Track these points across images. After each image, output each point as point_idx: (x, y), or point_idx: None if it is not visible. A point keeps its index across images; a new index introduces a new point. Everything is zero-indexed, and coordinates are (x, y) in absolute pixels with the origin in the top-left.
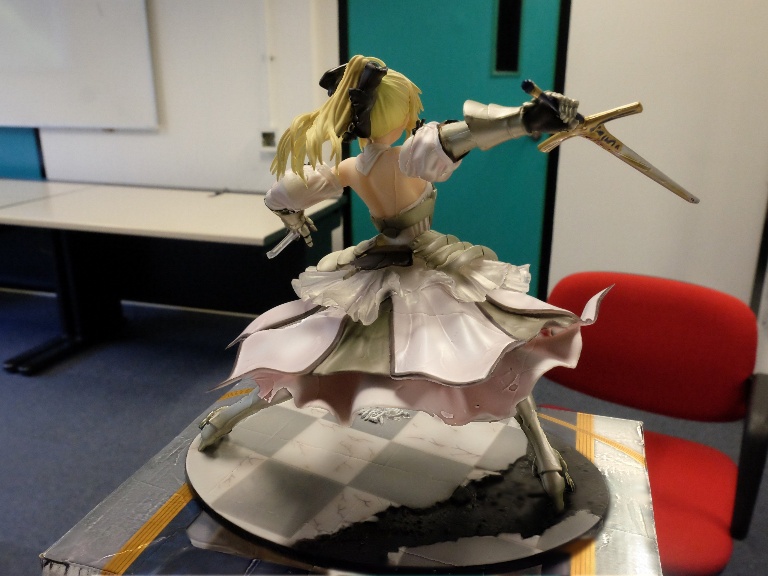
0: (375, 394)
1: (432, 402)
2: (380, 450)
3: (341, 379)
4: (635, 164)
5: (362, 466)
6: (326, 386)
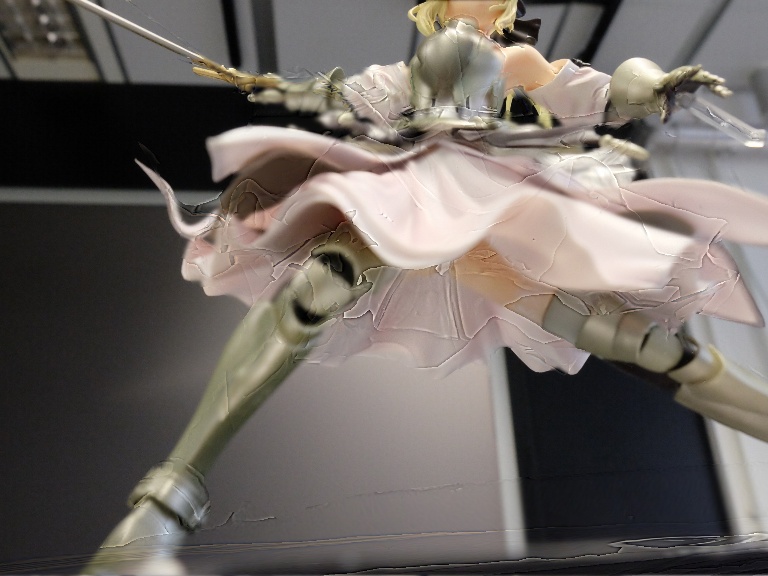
0: (389, 349)
1: (342, 350)
2: (671, 563)
3: (431, 339)
4: (144, 16)
5: (648, 575)
6: (449, 349)
